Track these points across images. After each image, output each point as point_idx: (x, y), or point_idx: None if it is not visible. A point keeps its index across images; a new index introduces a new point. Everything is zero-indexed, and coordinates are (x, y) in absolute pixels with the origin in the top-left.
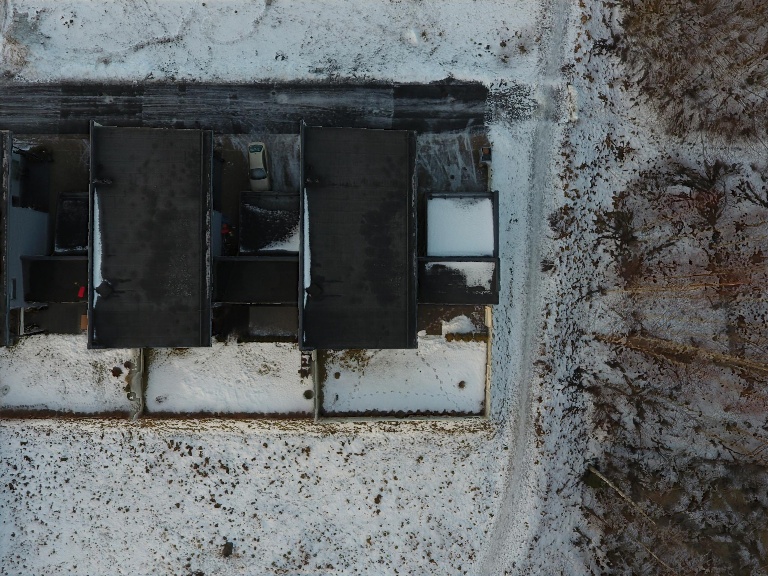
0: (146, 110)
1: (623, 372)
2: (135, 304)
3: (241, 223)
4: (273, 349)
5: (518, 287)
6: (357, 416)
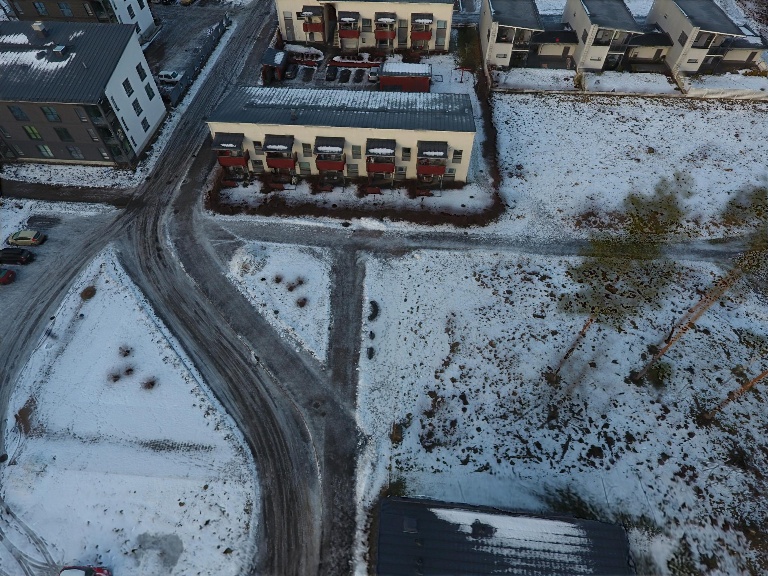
0: (555, 20)
1: None
2: None
3: None
4: (650, 75)
5: None
6: None
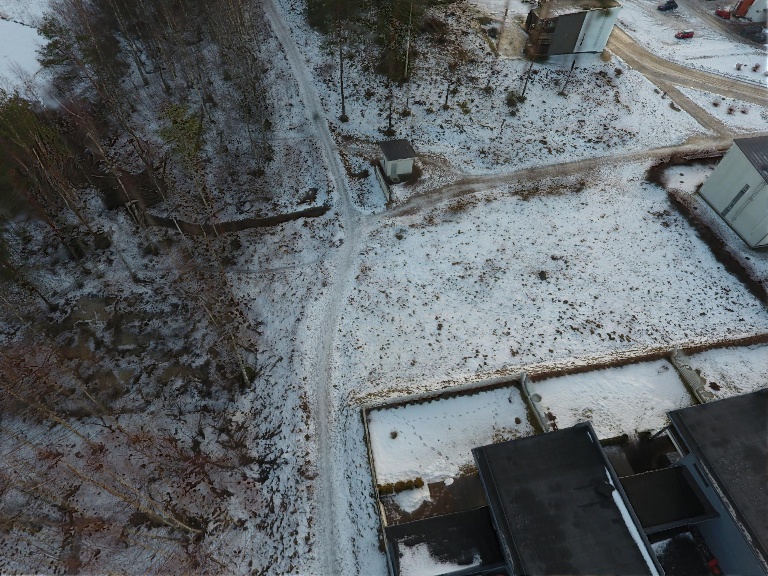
0: None
1: (213, 488)
2: (765, 439)
3: (710, 571)
4: None
5: (348, 567)
6: (486, 386)
